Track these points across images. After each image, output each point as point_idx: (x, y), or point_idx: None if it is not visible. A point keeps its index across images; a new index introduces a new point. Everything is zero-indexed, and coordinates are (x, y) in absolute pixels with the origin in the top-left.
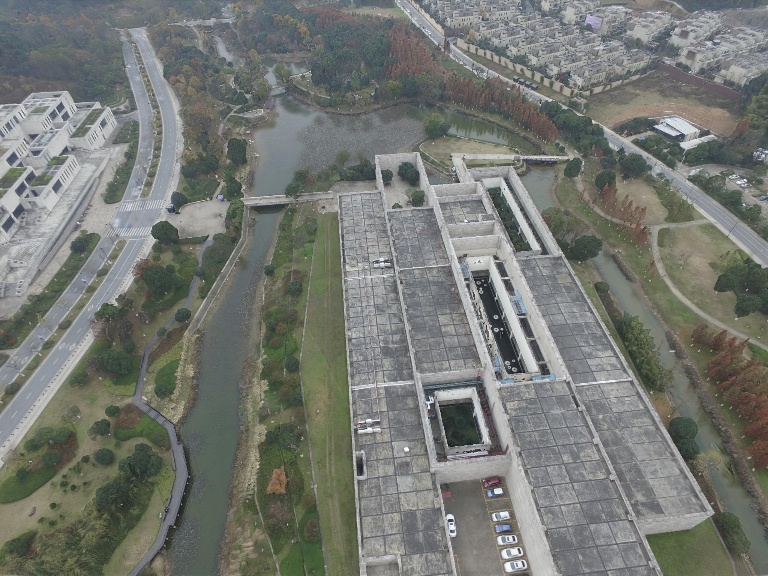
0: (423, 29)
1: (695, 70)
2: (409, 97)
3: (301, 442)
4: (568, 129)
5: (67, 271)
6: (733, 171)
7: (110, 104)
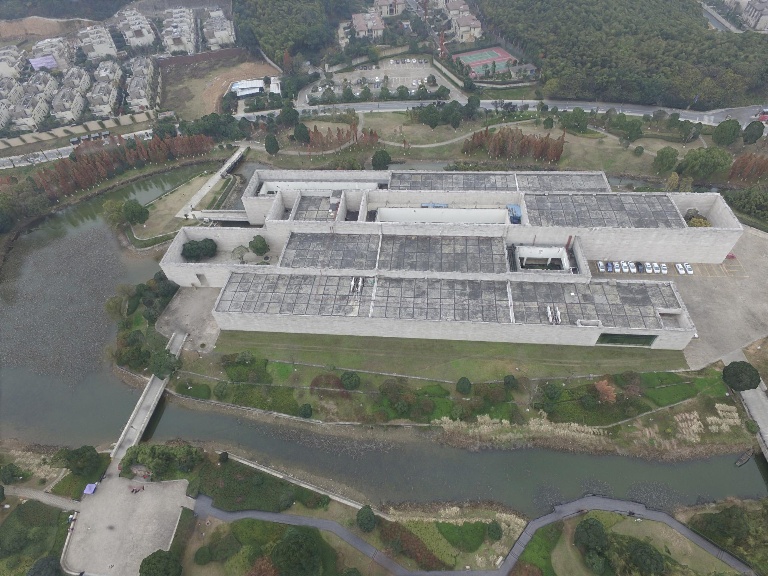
0: None
1: (191, 50)
2: (7, 231)
3: None
4: None
5: None
6: (316, 86)
7: None
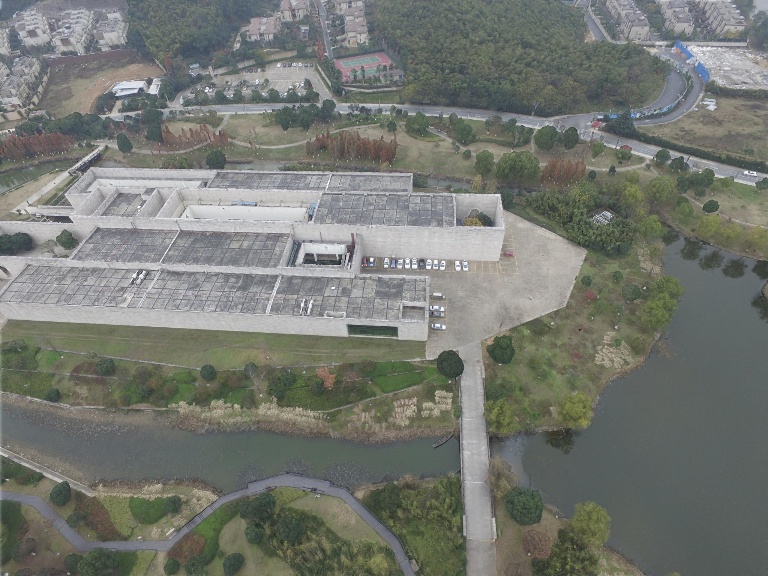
0: None
1: (81, 51)
2: None
3: None
4: (67, 133)
5: None
6: (195, 88)
7: None
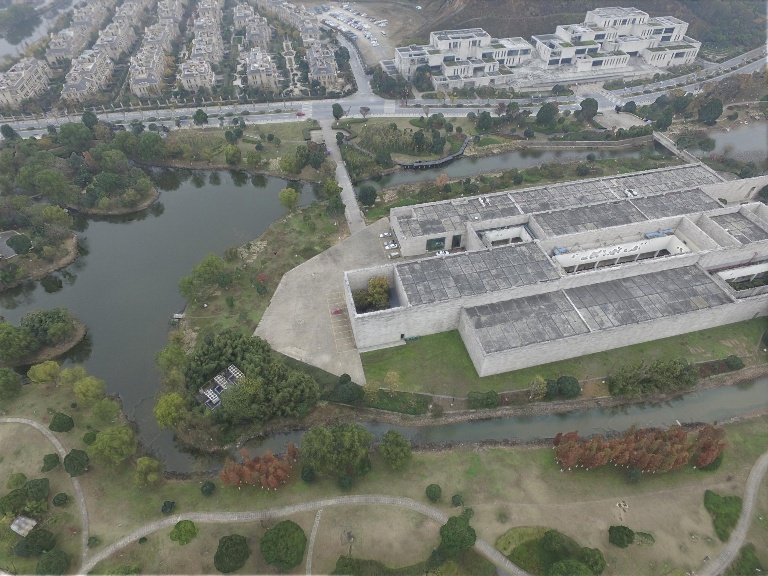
0: None
1: None
2: None
3: (470, 194)
4: None
5: (537, 93)
6: None
7: (711, 52)
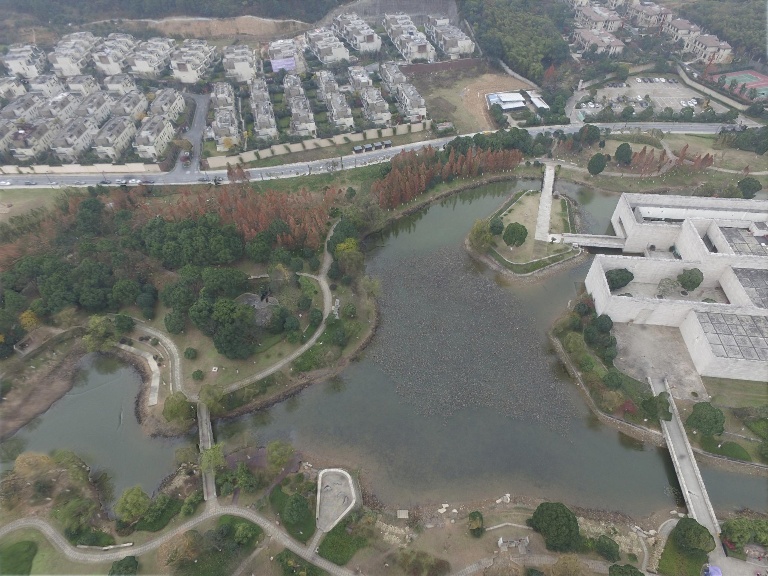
0: (110, 184)
1: (432, 59)
2: None
3: None
4: None
5: None
6: None
7: None
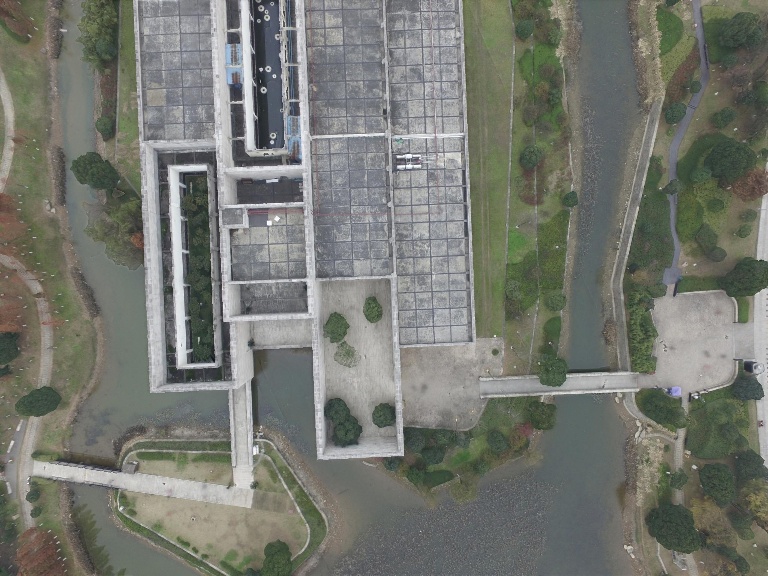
0: None
1: None
2: None
3: None
4: None
5: None
6: None
7: None
